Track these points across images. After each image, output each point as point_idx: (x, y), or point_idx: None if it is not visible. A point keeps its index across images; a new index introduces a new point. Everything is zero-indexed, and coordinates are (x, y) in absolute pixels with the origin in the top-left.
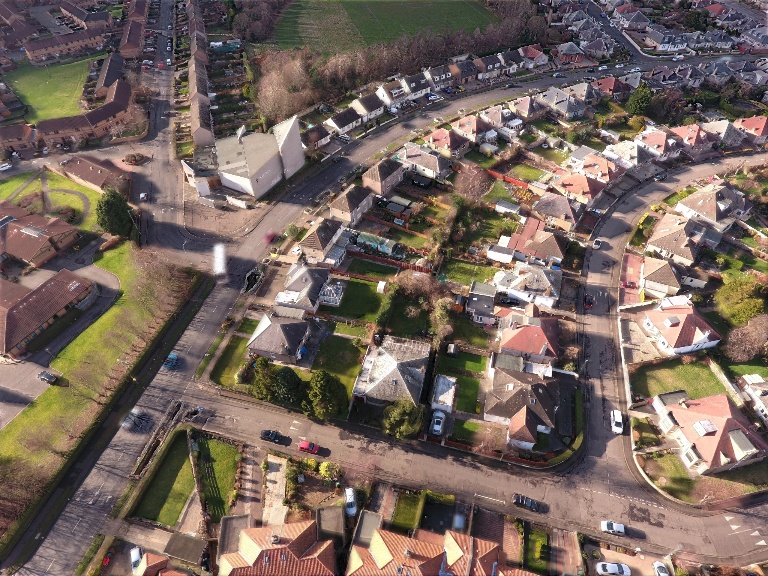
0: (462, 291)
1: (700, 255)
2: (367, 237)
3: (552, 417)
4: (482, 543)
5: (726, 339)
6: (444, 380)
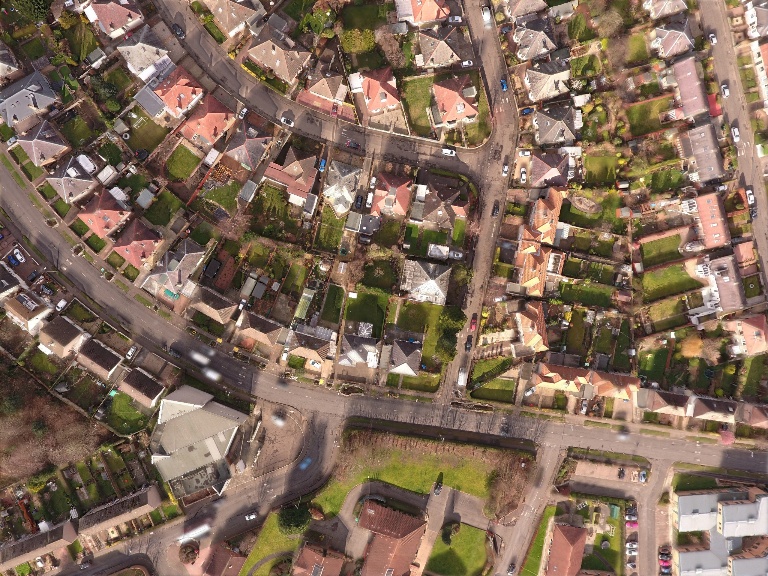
0: (350, 236)
1: (298, 42)
2: (302, 311)
3: (455, 191)
4: (525, 236)
5: (382, 59)
6: (433, 251)
